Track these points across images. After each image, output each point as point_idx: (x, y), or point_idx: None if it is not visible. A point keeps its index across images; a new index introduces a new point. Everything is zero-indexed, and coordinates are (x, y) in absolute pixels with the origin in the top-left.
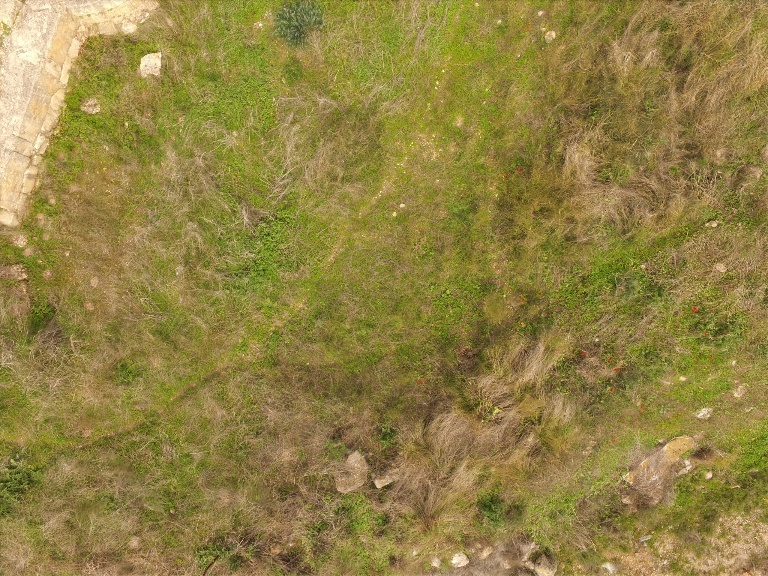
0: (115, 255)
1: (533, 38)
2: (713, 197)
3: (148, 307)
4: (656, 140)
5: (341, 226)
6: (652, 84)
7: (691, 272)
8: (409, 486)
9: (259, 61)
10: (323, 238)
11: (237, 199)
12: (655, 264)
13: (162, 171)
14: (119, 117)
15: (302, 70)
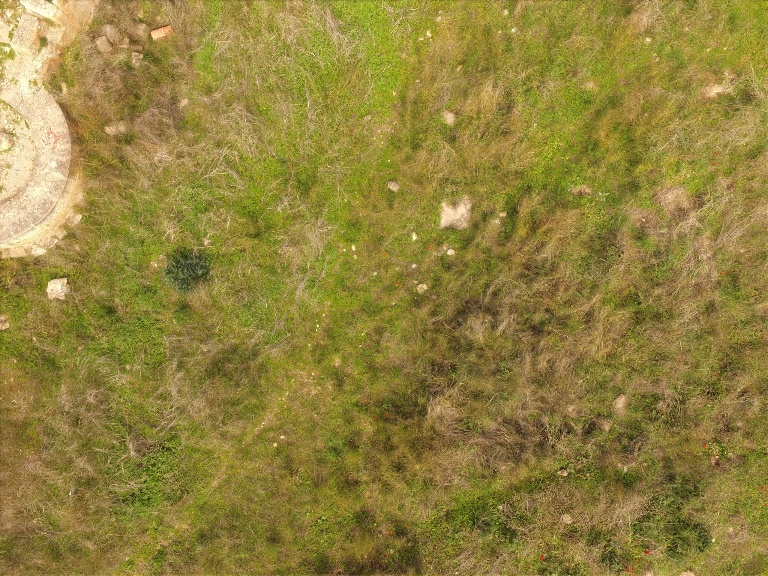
0: (16, 467)
1: (405, 292)
2: (565, 448)
3: (41, 526)
4: (512, 397)
5: (224, 455)
6: (507, 349)
7: (540, 522)
8: None
9: (151, 304)
10: (207, 466)
11: (127, 429)
12: (511, 507)
13: (56, 406)
14: (27, 333)
15: (191, 312)
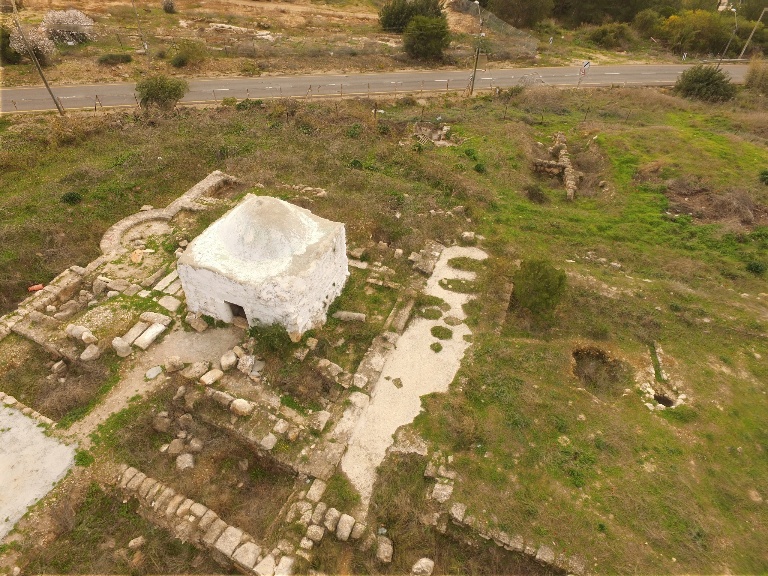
0: None
1: None
2: None
3: None
4: None
5: None
6: None
7: None
8: (109, 120)
9: None
10: None
11: None
12: None
13: None
14: None
15: None
